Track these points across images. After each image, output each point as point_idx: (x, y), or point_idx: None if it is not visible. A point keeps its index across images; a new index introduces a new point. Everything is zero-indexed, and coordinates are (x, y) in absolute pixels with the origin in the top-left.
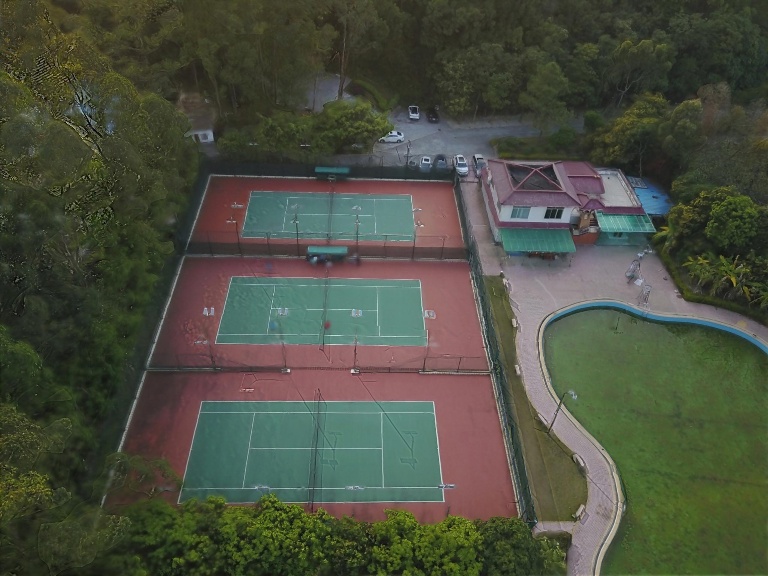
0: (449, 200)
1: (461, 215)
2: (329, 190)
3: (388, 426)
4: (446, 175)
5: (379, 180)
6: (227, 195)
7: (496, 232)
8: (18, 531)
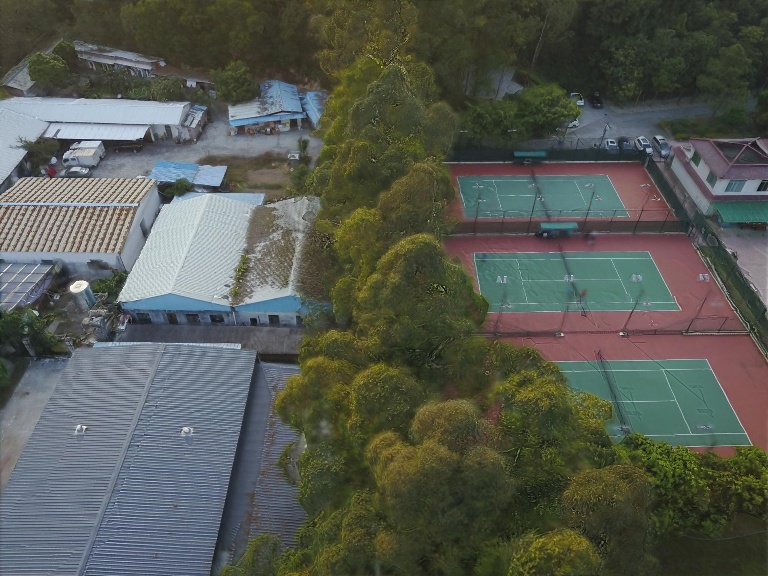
0: (644, 179)
1: (665, 192)
2: (530, 173)
3: (674, 381)
4: (633, 156)
5: (571, 162)
6: None
7: (706, 206)
8: None
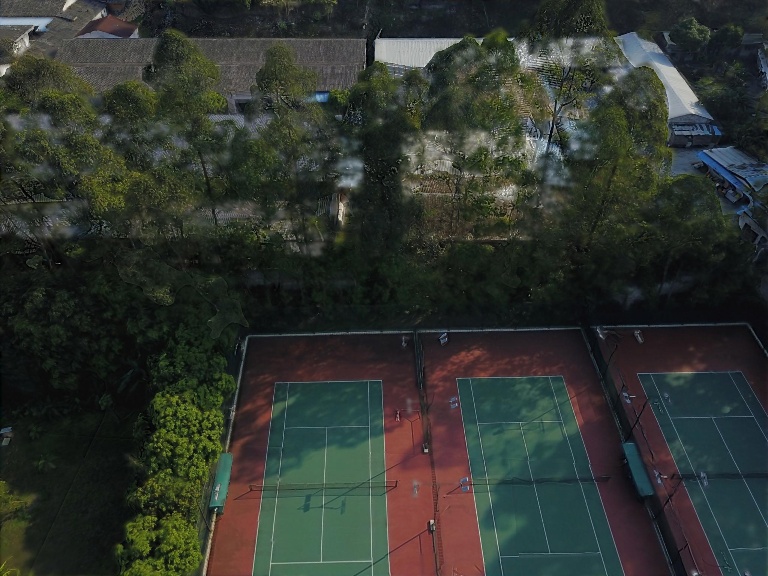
0: None
1: None
2: None
3: (353, 569)
4: None
5: None
6: (715, 347)
7: None
8: (229, 279)
